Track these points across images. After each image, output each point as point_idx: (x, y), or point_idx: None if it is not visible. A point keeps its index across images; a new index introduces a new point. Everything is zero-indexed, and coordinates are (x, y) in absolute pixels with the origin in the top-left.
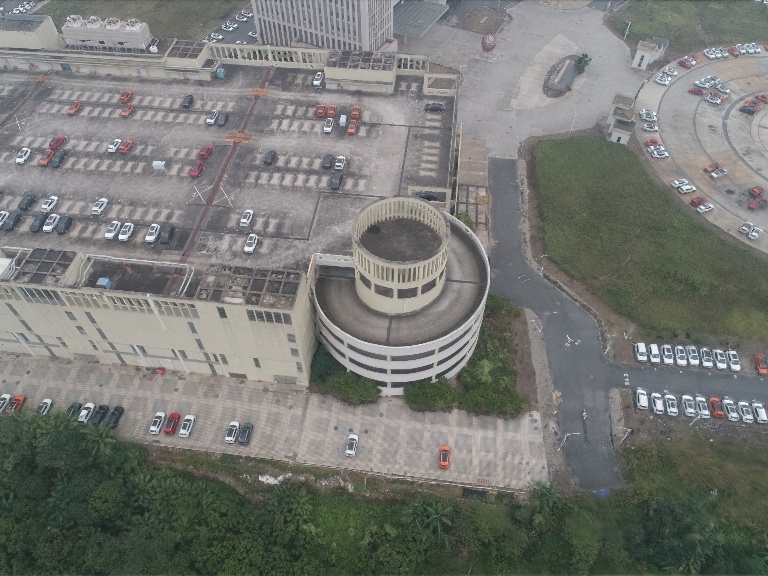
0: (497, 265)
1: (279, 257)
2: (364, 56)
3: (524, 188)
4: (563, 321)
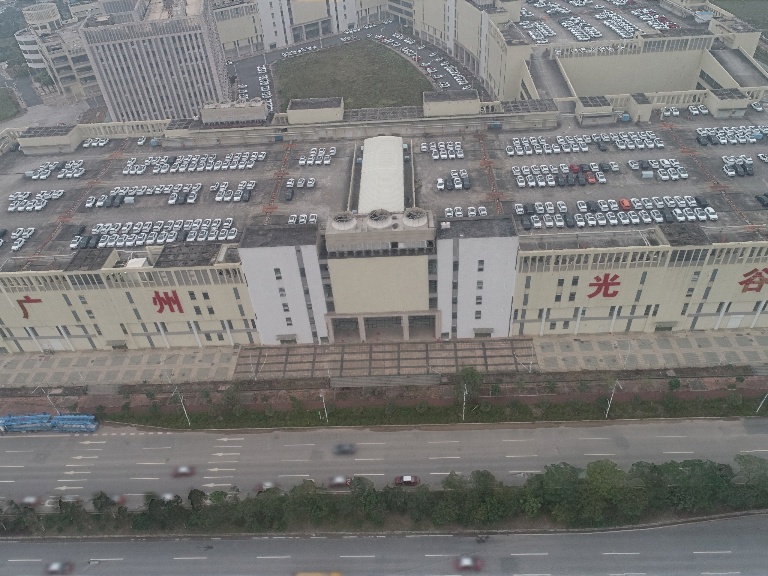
0: None
1: None
2: None
3: (20, 101)
4: None
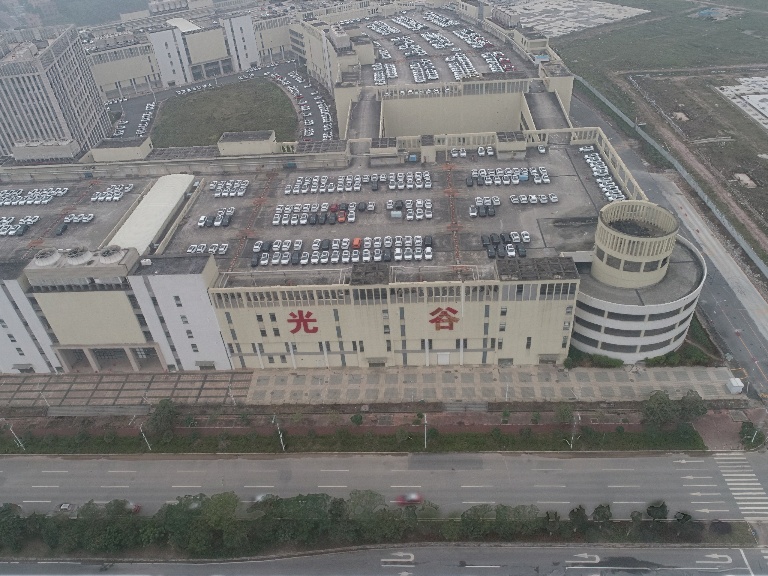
0: None
1: None
2: None
3: None
4: None
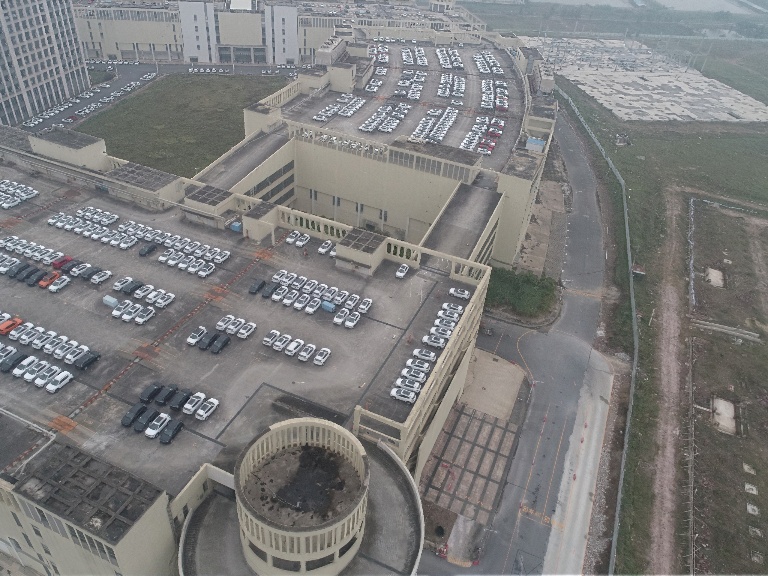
0: None
1: None
2: None
3: None
4: None
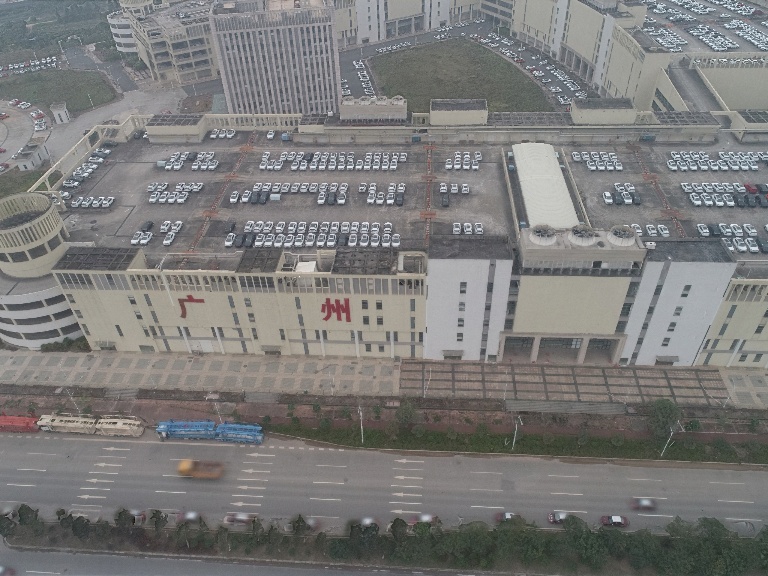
0: (119, 67)
1: (182, 4)
2: (199, 22)
3: (115, 85)
4: (86, 65)
